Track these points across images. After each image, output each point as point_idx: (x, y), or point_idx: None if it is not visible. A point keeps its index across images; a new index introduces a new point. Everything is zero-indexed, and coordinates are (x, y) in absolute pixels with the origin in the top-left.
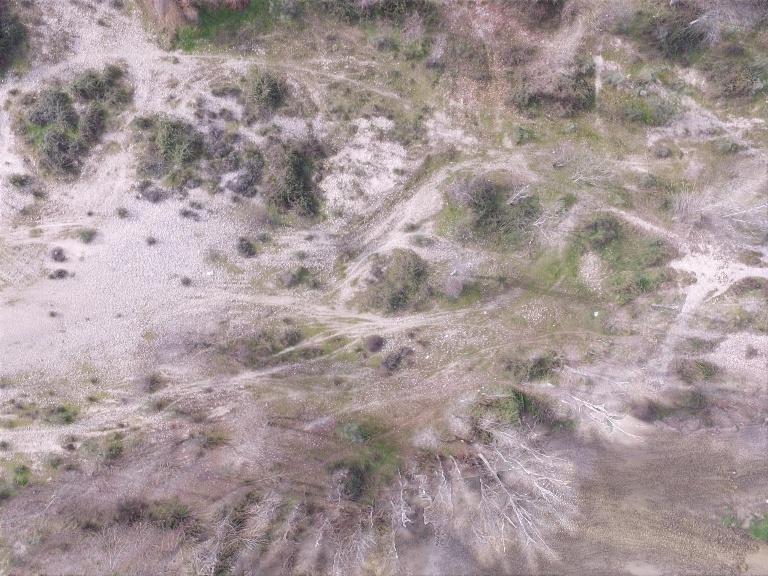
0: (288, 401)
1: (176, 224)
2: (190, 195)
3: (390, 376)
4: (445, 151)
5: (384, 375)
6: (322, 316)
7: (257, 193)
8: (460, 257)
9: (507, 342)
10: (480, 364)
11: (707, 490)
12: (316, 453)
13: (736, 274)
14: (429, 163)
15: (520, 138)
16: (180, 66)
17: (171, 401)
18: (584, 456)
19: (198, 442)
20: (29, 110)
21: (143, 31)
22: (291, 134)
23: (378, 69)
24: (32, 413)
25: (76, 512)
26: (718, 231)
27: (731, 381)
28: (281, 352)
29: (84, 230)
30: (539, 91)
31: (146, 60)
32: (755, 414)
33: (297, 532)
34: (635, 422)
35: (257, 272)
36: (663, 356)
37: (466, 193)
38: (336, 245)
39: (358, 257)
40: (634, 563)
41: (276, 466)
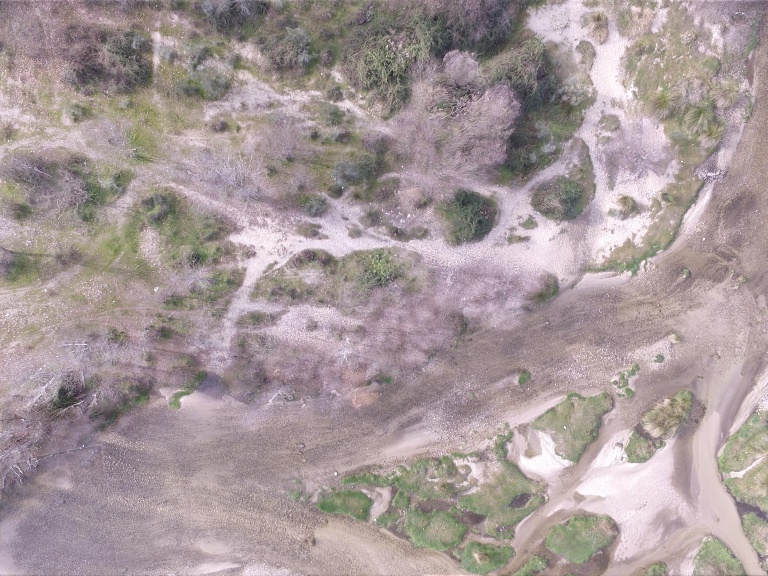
0: None
1: None
2: None
3: None
4: (0, 129)
5: None
6: None
7: None
8: (19, 235)
9: (68, 319)
10: (41, 342)
11: (276, 464)
12: None
13: (295, 246)
14: None
15: (73, 115)
16: None
17: None
18: (153, 433)
19: None
20: None
21: None
22: None
23: None
24: None
25: None
26: (276, 204)
27: (292, 353)
28: None
29: None
30: (87, 67)
31: None
32: (320, 386)
33: None
34: (203, 397)
35: None
36: (225, 330)
37: None
38: None
39: None
40: (204, 539)
41: None
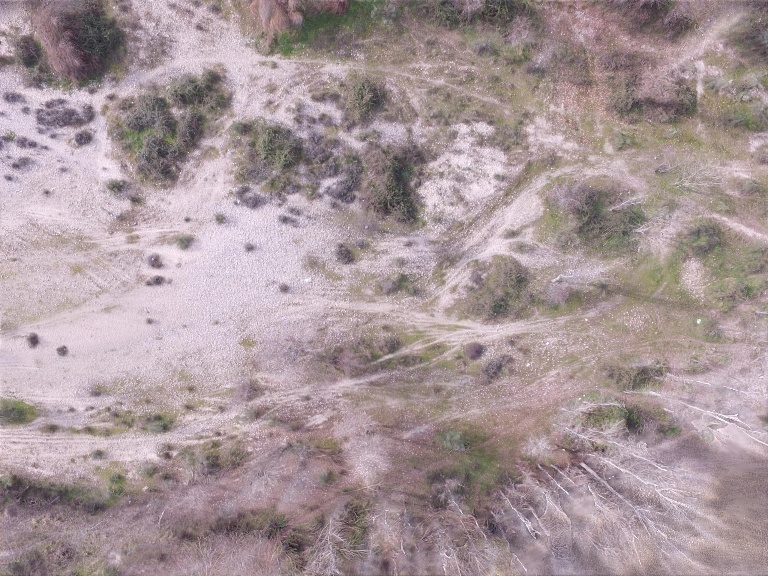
0: (387, 409)
1: (274, 230)
2: (289, 201)
3: (490, 384)
4: (546, 157)
5: (484, 383)
6: (421, 323)
7: (356, 199)
8: (561, 264)
9: (608, 350)
10: (581, 372)
11: None
12: (415, 462)
13: None
14: (530, 169)
15: (622, 144)
16: (278, 71)
17: (268, 409)
18: (685, 465)
19: (296, 451)
20: (127, 115)
21: (241, 36)
22: (391, 139)
23: (477, 74)
24: (128, 421)
25: (171, 522)
26: None
27: None
28: (380, 360)
29: (182, 236)
30: (642, 96)
31: (244, 65)
32: None
33: (397, 542)
34: (737, 431)
35: (356, 279)
36: (766, 364)
37: None
38: (436, 251)
39: (457, 264)
40: (737, 574)
41: (374, 475)
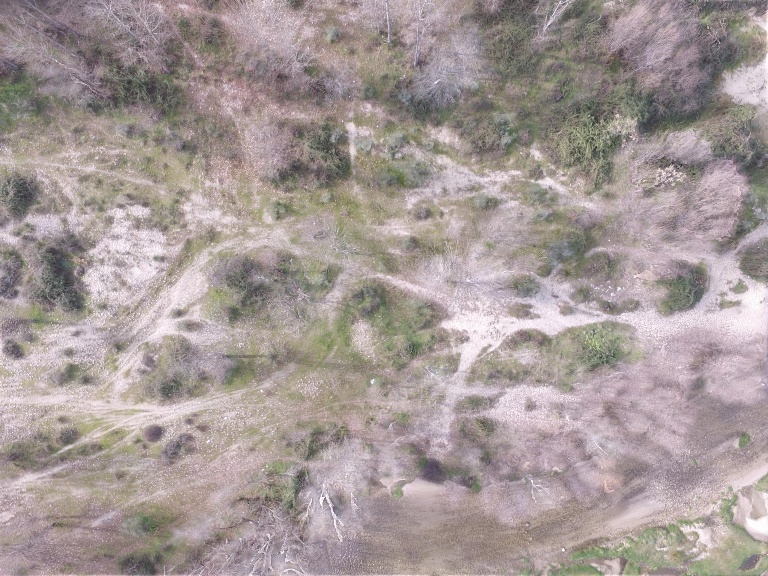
0: (72, 500)
1: None
2: None
3: (172, 464)
4: (204, 233)
5: (166, 464)
6: (98, 411)
7: (19, 294)
8: (230, 338)
9: (286, 418)
10: (262, 443)
11: (503, 545)
12: (105, 549)
13: (508, 328)
14: (190, 247)
15: (277, 214)
16: None
17: None
18: (377, 523)
19: None
20: None
21: None
22: (46, 231)
23: (130, 157)
24: None
25: None
26: (485, 287)
27: (513, 435)
28: (60, 451)
29: None
30: (289, 165)
31: None
32: (542, 465)
33: None
34: (424, 484)
35: (27, 373)
36: (444, 416)
37: (215, 279)
38: (104, 338)
39: (128, 348)
40: None
41: (66, 566)
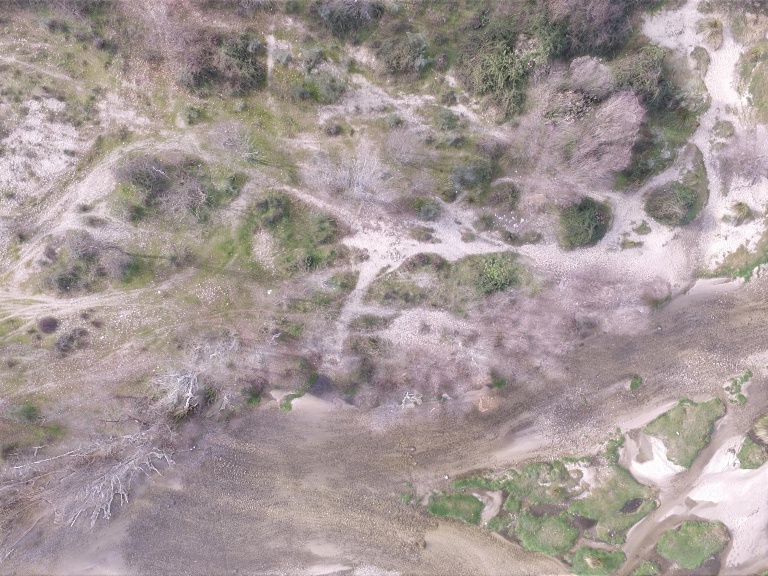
0: None
1: None
2: None
3: (65, 357)
4: (116, 131)
5: (58, 356)
6: None
7: None
8: (133, 237)
9: (181, 321)
10: (155, 344)
11: (387, 467)
12: None
13: (408, 250)
14: (101, 144)
15: (189, 117)
16: None
17: None
18: (264, 435)
19: None
20: None
21: None
22: None
23: (51, 51)
24: None
25: None
26: (389, 207)
27: (404, 357)
28: None
29: None
30: (204, 70)
31: None
32: (432, 390)
33: None
34: (314, 400)
35: None
36: (338, 333)
37: (116, 172)
38: (9, 227)
39: (32, 239)
40: (314, 542)
41: None
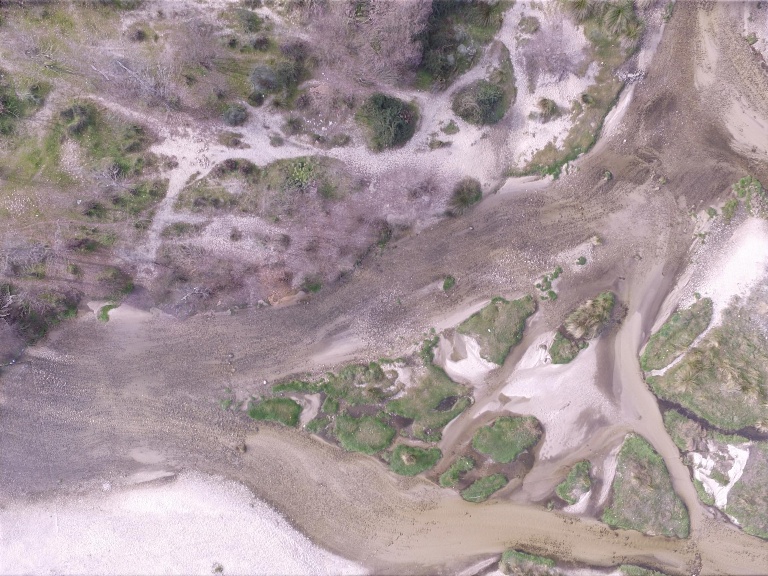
0: None
1: None
2: None
3: None
4: None
5: None
6: None
7: None
8: None
9: None
10: None
11: (206, 374)
12: None
13: (217, 156)
14: None
15: None
16: None
17: None
18: (82, 346)
19: None
20: None
21: None
22: None
23: None
24: None
25: None
26: (197, 113)
27: (217, 264)
28: None
29: None
30: None
31: None
32: (247, 296)
33: None
34: (130, 310)
35: None
36: (150, 242)
37: None
38: None
39: None
40: (136, 450)
41: None
